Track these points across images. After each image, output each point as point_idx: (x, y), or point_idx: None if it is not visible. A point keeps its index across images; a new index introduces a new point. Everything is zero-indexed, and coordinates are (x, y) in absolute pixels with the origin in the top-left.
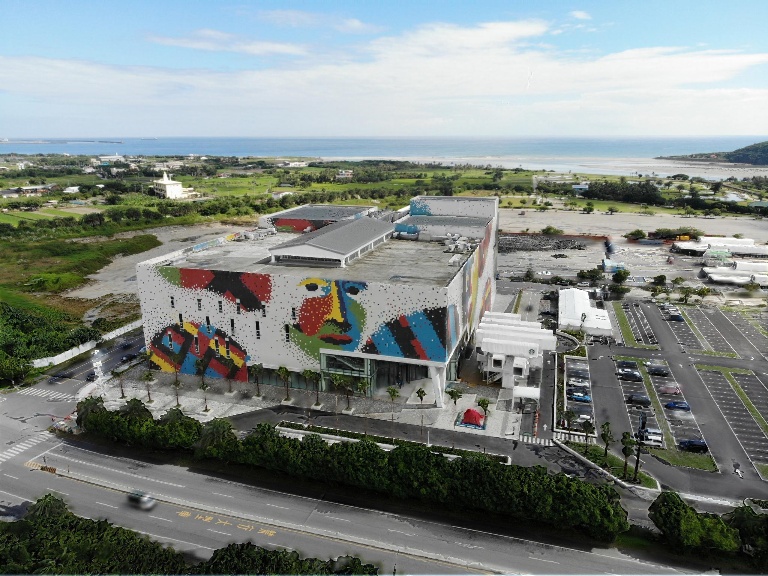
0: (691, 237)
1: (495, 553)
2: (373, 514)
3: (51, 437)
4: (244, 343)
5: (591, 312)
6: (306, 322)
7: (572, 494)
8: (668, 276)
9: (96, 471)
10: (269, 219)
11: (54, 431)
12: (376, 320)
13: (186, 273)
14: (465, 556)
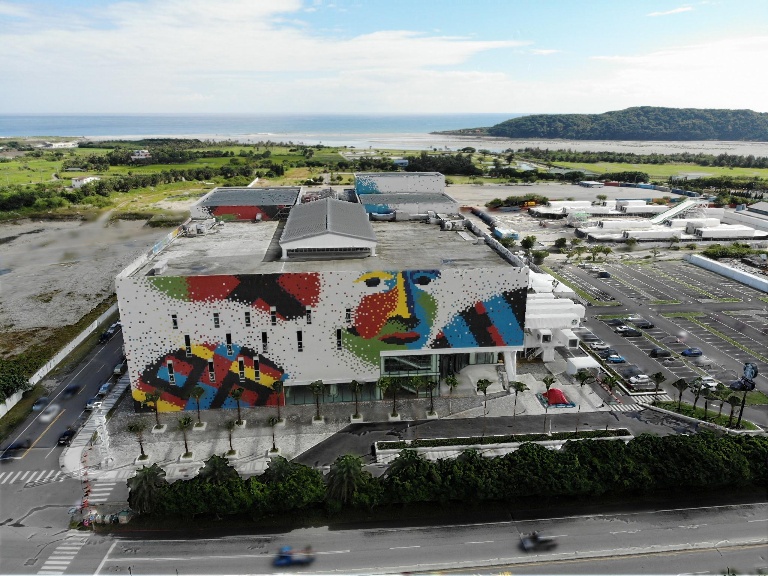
0: (536, 202)
1: (720, 526)
2: (579, 521)
3: (90, 536)
4: (280, 359)
5: (542, 278)
6: (364, 323)
7: (766, 451)
8: (555, 238)
9: (210, 565)
10: (204, 208)
11: (87, 527)
12: (449, 310)
13: (197, 282)
14: (700, 538)
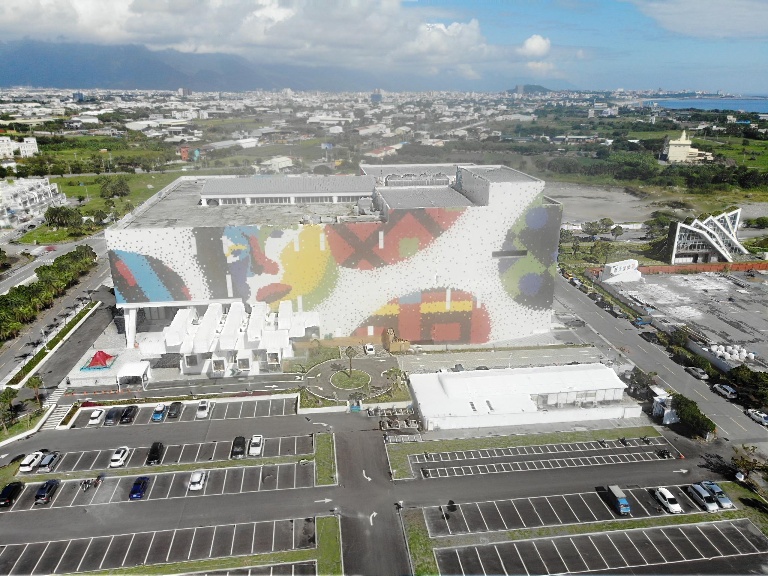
0: None
1: None
2: None
3: None
4: None
5: (496, 394)
6: None
7: None
8: None
9: None
10: None
11: None
12: None
13: None
14: None
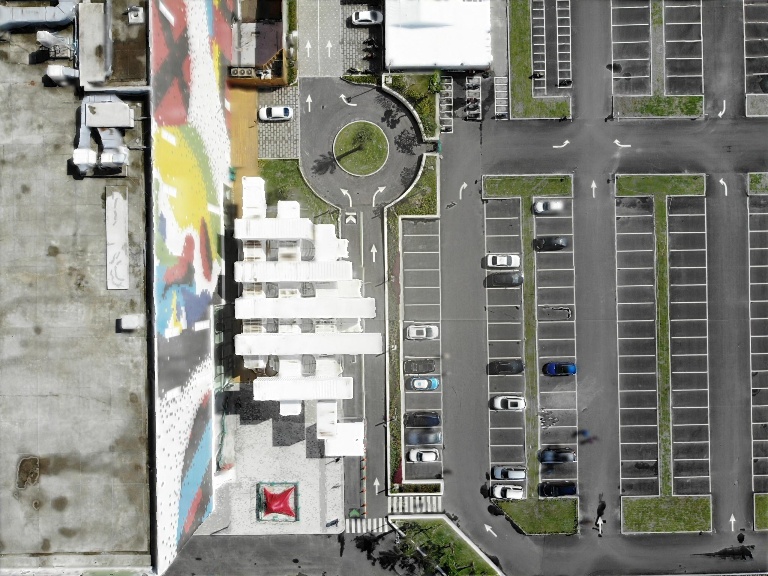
0: None
1: None
2: None
3: None
4: None
5: None
6: None
7: None
8: None
9: None
10: None
11: None
12: None
13: None
14: None
